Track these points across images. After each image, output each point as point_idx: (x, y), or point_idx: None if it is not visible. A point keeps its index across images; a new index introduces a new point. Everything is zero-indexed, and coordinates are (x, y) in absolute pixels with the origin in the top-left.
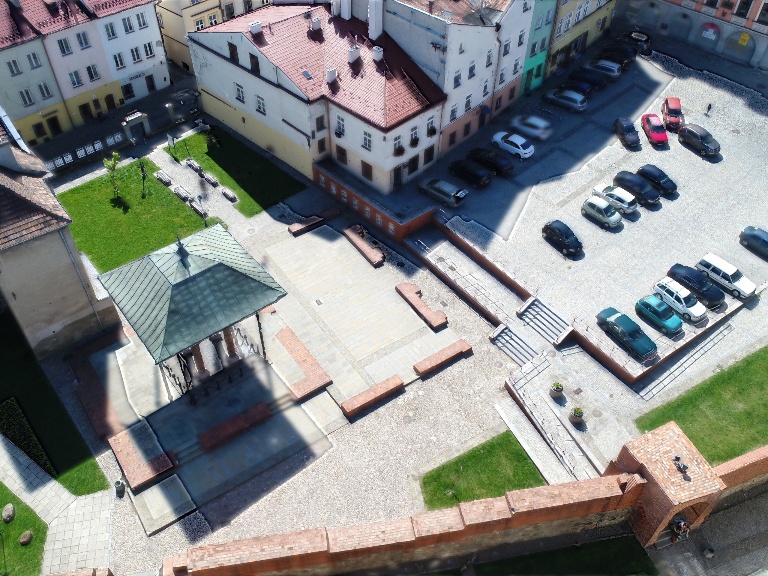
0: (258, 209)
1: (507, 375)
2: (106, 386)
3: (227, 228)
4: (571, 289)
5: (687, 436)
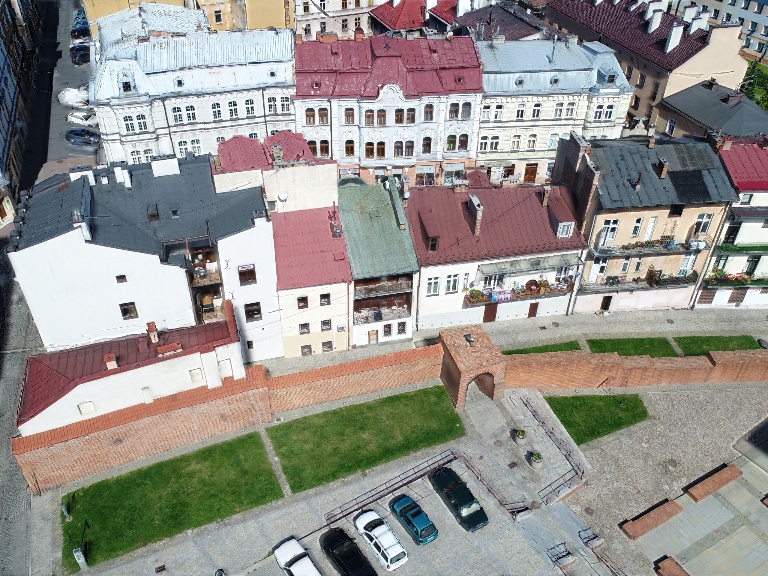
0: None
1: (581, 498)
2: None
3: None
4: (510, 575)
5: (426, 416)
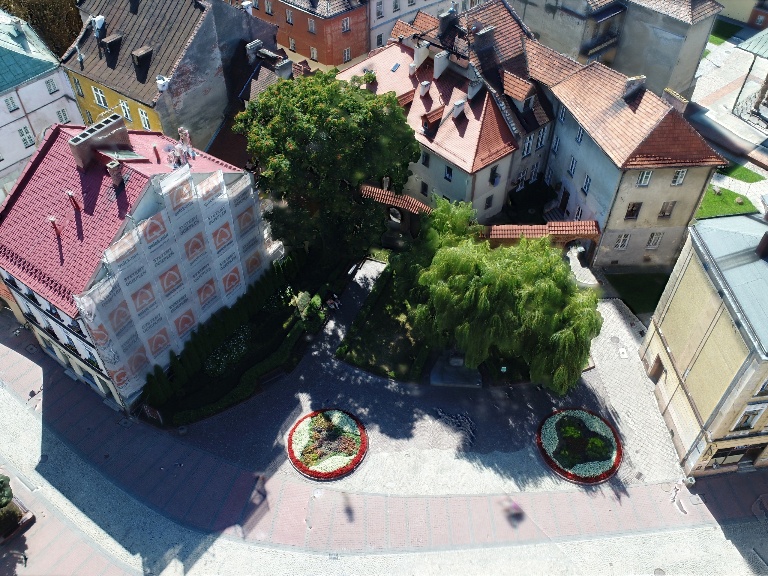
0: (721, 40)
1: None
2: (718, 130)
3: (710, 51)
4: None
5: None
